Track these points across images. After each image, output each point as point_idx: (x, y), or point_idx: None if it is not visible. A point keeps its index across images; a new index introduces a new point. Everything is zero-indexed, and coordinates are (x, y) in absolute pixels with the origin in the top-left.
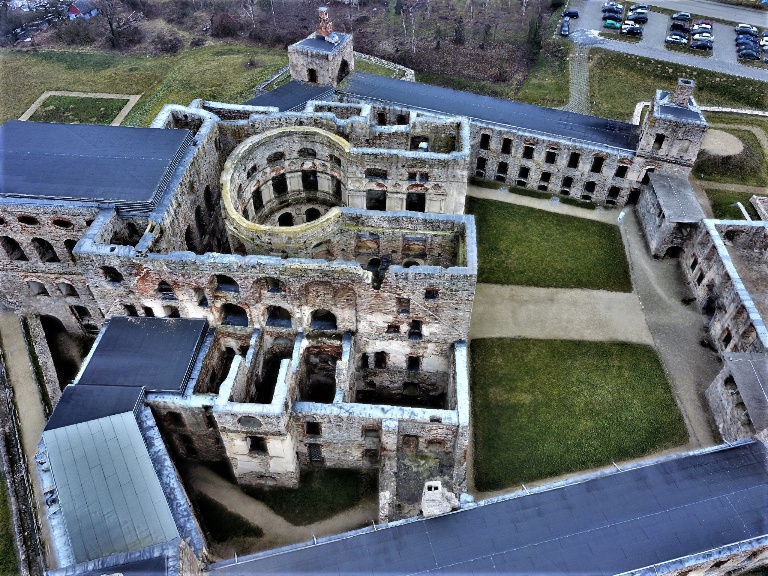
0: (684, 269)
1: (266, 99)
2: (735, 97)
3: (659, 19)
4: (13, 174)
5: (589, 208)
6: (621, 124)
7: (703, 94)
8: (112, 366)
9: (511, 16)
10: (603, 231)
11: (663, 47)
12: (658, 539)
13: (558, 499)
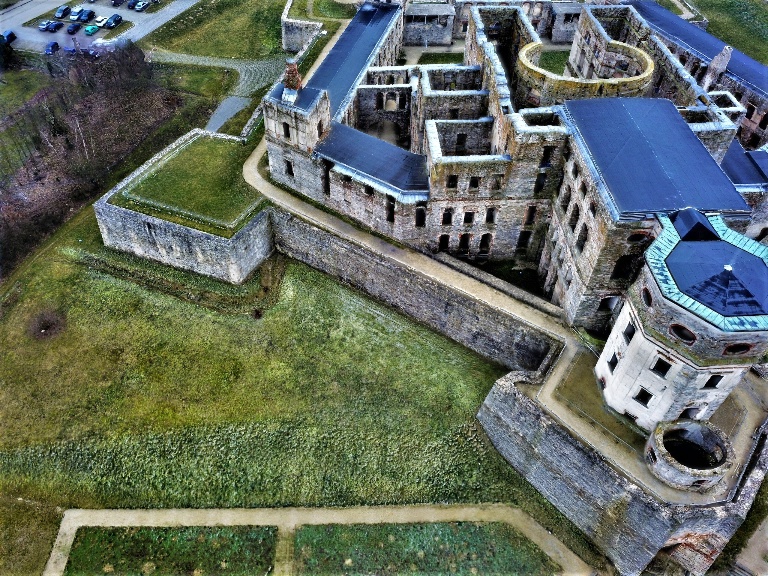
0: (460, 36)
1: (363, 161)
2: (236, 3)
3: (89, 8)
4: (699, 173)
5: (405, 61)
6: (366, 7)
7: (226, 14)
8: (742, 172)
9: (9, 92)
10: (430, 58)
11: (148, 14)
12: (686, 24)
13: (688, 41)
